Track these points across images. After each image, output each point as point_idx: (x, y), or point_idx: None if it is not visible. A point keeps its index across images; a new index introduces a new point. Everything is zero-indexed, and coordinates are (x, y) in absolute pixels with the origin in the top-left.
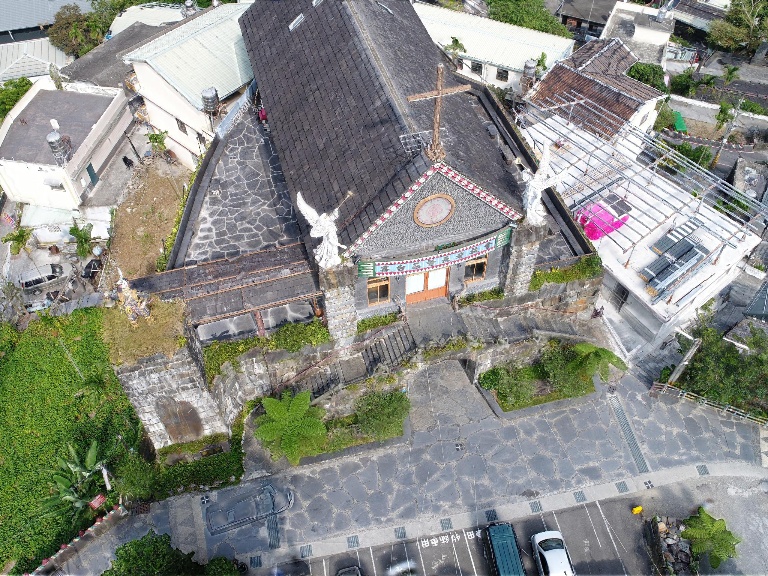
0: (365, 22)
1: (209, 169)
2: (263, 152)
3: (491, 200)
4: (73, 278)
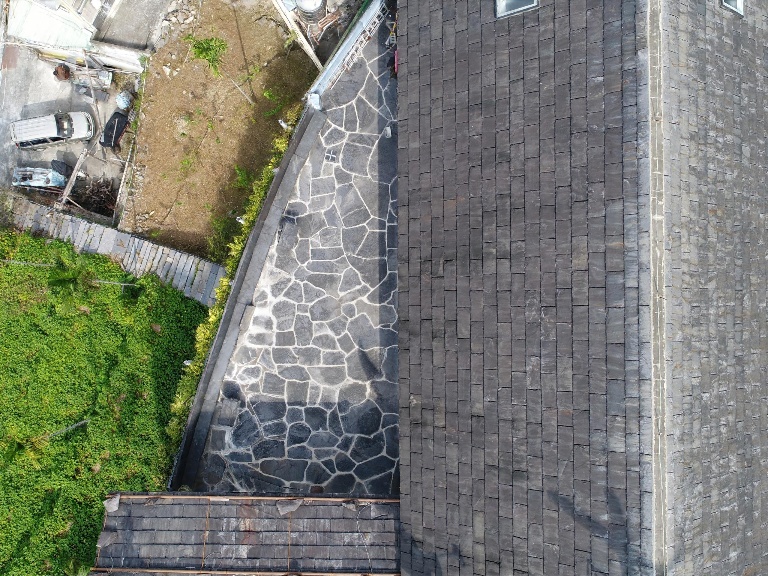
0: (670, 148)
1: (285, 186)
2: (384, 159)
3: None
4: (88, 140)
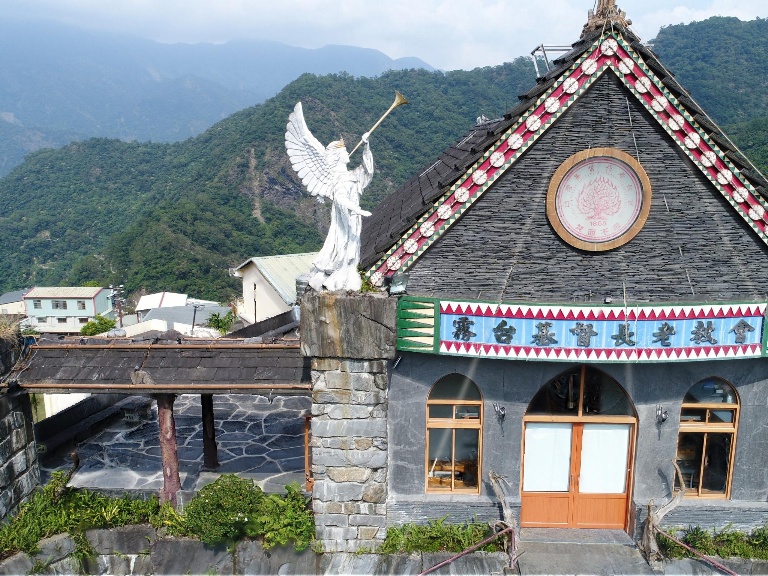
0: None
1: None
2: None
3: (746, 201)
4: None
